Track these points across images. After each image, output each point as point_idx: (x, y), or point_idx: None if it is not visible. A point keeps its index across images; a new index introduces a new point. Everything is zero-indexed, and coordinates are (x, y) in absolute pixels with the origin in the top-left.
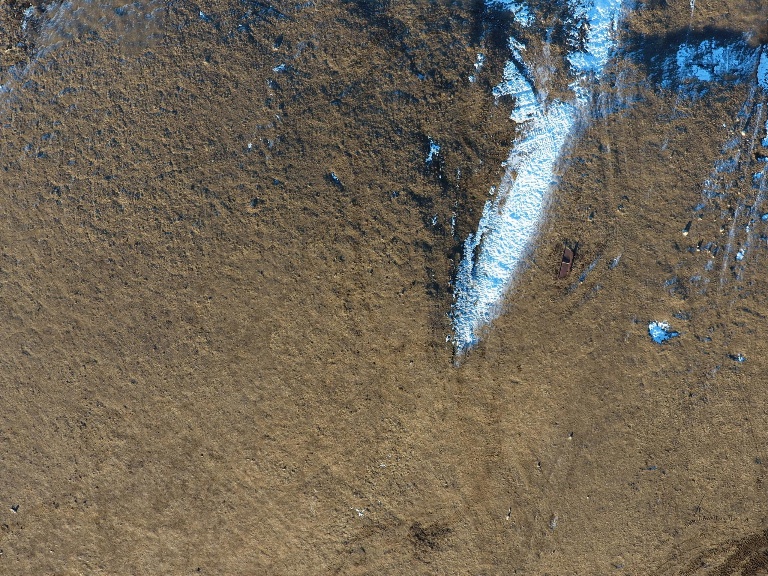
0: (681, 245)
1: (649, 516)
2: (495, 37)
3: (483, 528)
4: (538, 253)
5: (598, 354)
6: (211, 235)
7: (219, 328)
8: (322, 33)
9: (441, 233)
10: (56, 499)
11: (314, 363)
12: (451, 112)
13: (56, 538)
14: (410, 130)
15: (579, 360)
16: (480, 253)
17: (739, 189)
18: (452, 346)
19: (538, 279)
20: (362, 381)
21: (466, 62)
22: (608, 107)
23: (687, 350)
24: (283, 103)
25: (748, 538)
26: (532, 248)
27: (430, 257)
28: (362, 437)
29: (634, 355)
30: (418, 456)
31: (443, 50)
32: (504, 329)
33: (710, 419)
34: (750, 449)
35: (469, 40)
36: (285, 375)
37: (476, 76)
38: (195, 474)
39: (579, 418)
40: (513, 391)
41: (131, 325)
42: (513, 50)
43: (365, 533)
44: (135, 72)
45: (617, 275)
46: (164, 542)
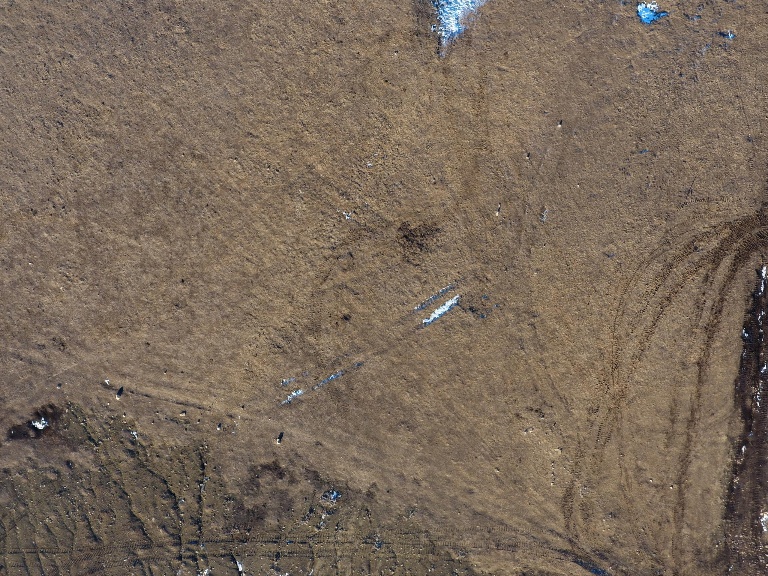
0: None
1: (640, 201)
2: None
3: (472, 226)
4: None
5: (586, 38)
6: None
7: (198, 18)
8: None
9: None
10: (34, 205)
11: (297, 54)
12: None
13: (35, 248)
14: None
15: (567, 45)
16: None
17: None
18: (438, 36)
19: None
20: (346, 73)
21: None
22: None
23: (676, 29)
24: None
25: (741, 219)
26: None
27: None
28: (347, 134)
29: (623, 37)
30: (405, 153)
31: None
32: (490, 15)
33: (701, 98)
34: (741, 127)
35: None
36: (267, 68)
37: None
38: (177, 175)
39: (568, 105)
40: (500, 79)
41: (107, 17)
42: None
43: (352, 237)
44: None
45: None
46: (146, 251)
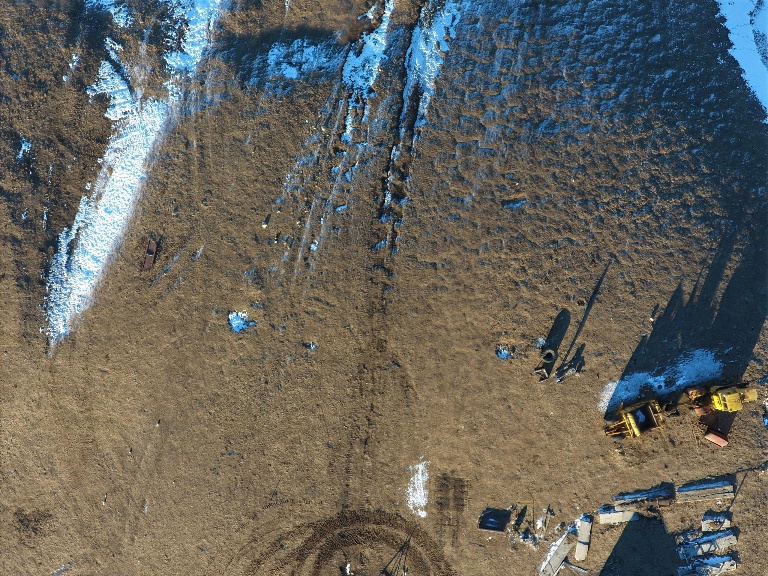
0: (260, 237)
1: (230, 500)
2: (91, 37)
3: (82, 513)
4: (125, 246)
5: (181, 343)
6: None
7: None
8: None
9: (31, 227)
10: None
11: None
12: (44, 110)
13: None
14: (2, 128)
15: (164, 349)
16: (76, 246)
17: (316, 182)
18: (46, 337)
19: (124, 271)
20: None
21: (60, 62)
22: (197, 104)
23: (263, 338)
24: None
25: (323, 520)
26: (120, 241)
27: (19, 251)
28: None
29: (214, 344)
30: (18, 444)
31: (38, 50)
32: (93, 320)
33: (284, 405)
34: (322, 434)
35: (64, 41)
36: None
37: (70, 75)
38: None
39: (165, 405)
40: (102, 380)
41: None
42: (109, 50)
43: None
44: None
45: (199, 266)
46: None
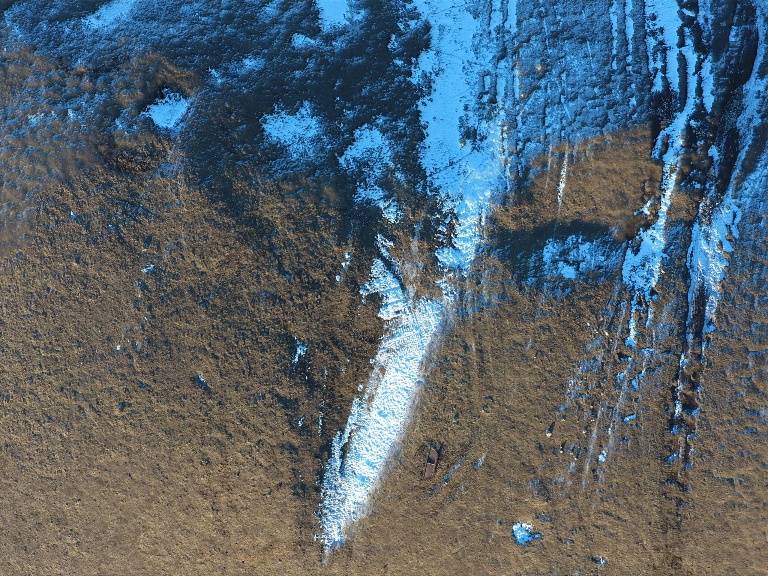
0: (545, 446)
1: None
2: (363, 235)
3: None
4: (404, 453)
5: (463, 554)
6: (80, 438)
7: (88, 529)
8: (191, 233)
9: (308, 434)
10: None
11: (183, 563)
12: (318, 312)
13: None
14: (277, 331)
15: (445, 560)
16: (349, 450)
17: (602, 390)
18: (320, 544)
19: (404, 480)
20: None
21: (333, 261)
22: (474, 306)
23: (550, 552)
24: (151, 305)
25: None
26: (398, 448)
27: (296, 458)
28: None
29: (498, 556)
30: None
31: (310, 249)
32: (371, 529)
33: None
34: None
35: (336, 239)
36: (155, 574)
37: (343, 275)
38: None
39: None
40: None
41: (2, 526)
42: (381, 247)
43: None
44: (6, 273)
45: (481, 476)
46: None
